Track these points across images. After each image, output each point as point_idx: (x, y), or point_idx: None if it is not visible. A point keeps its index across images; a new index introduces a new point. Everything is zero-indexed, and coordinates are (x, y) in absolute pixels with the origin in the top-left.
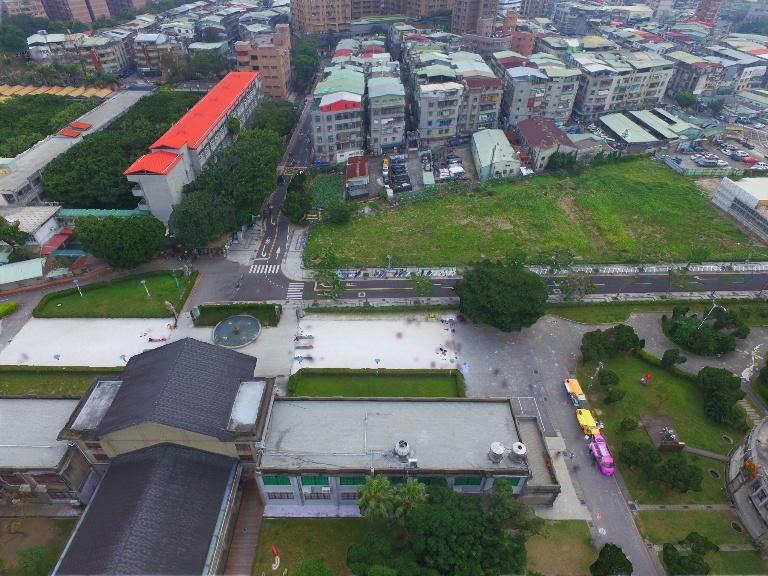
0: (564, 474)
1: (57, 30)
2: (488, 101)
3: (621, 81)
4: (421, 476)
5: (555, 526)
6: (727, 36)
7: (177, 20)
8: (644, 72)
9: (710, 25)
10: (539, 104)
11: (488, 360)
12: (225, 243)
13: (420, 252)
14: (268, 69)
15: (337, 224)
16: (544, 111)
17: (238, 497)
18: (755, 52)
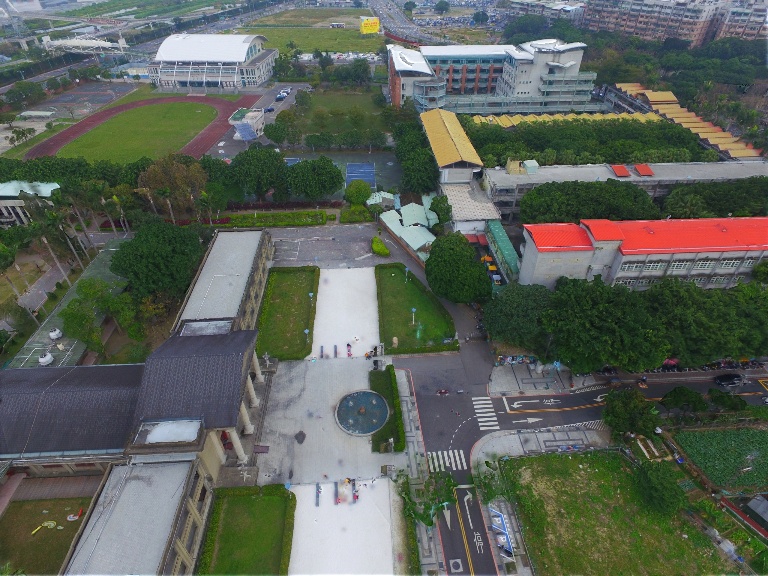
0: None
1: None
2: None
3: None
4: None
5: None
6: None
7: None
8: None
9: None
10: None
11: None
12: (506, 354)
13: None
14: None
15: (643, 493)
16: None
17: None
18: None
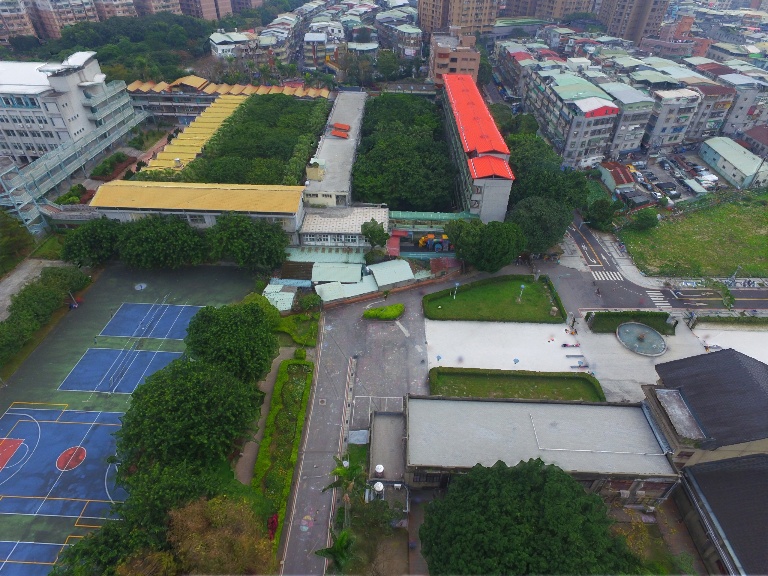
0: None
1: (209, 28)
2: (720, 108)
3: None
4: None
5: None
6: None
7: (320, 19)
8: None
9: None
10: (757, 112)
11: None
12: (561, 249)
13: (748, 262)
14: (465, 71)
15: (640, 231)
16: None
17: None
18: None
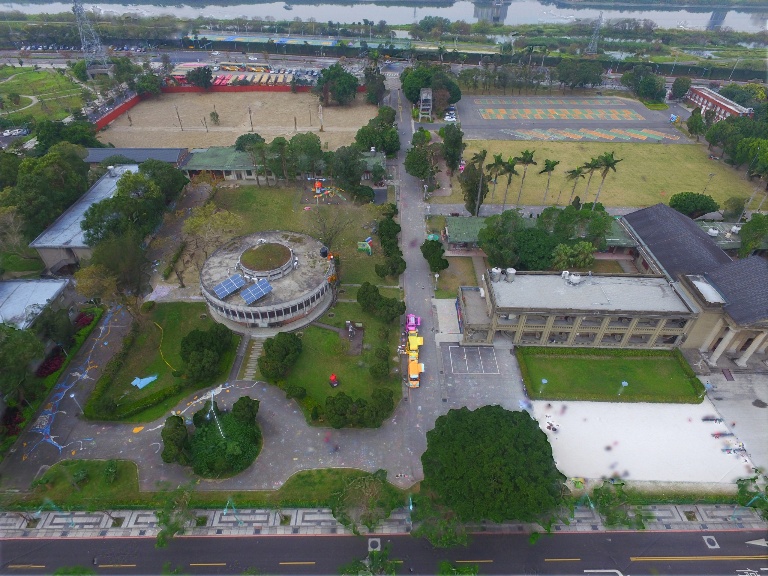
0: (442, 319)
1: None
2: None
3: None
4: None
5: None
6: None
7: None
8: None
9: None
10: None
11: None
12: None
13: None
14: None
15: None
16: None
17: None
18: None
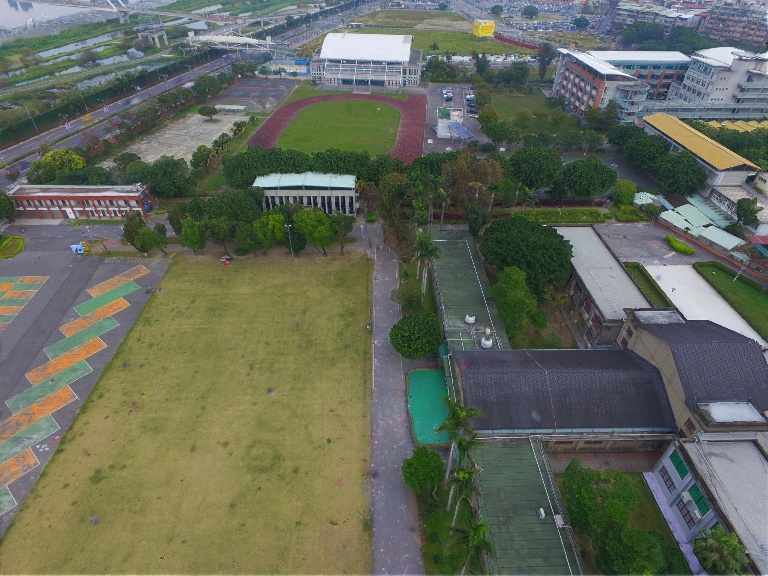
0: None
1: None
2: None
3: None
4: None
5: None
6: None
7: None
8: None
9: None
10: None
11: None
12: None
13: None
14: None
15: None
16: None
17: (647, 448)
18: None
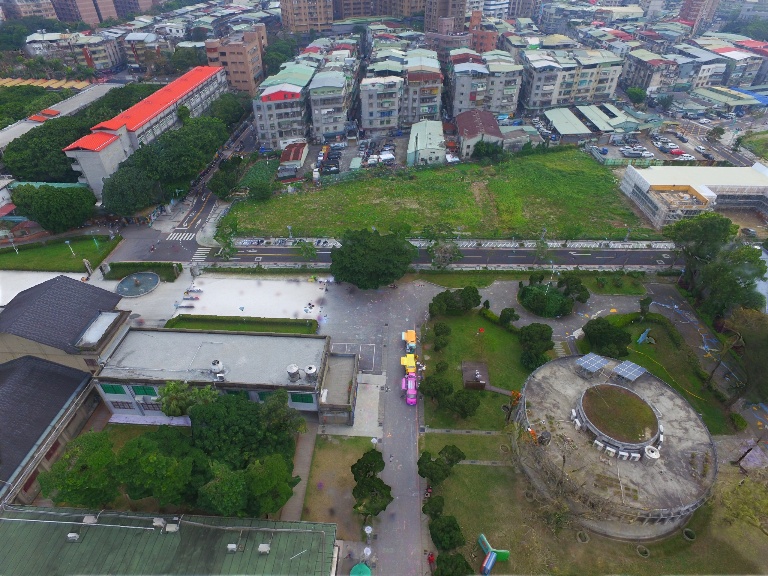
0: (374, 403)
1: (62, 30)
2: (428, 94)
3: (567, 77)
4: (227, 389)
5: (348, 440)
6: (701, 35)
7: (172, 21)
8: (591, 68)
9: (690, 25)
10: (482, 98)
11: (347, 314)
12: (150, 213)
13: (324, 226)
14: (236, 65)
15: (259, 201)
16: (489, 105)
17: (93, 407)
18: (719, 50)
